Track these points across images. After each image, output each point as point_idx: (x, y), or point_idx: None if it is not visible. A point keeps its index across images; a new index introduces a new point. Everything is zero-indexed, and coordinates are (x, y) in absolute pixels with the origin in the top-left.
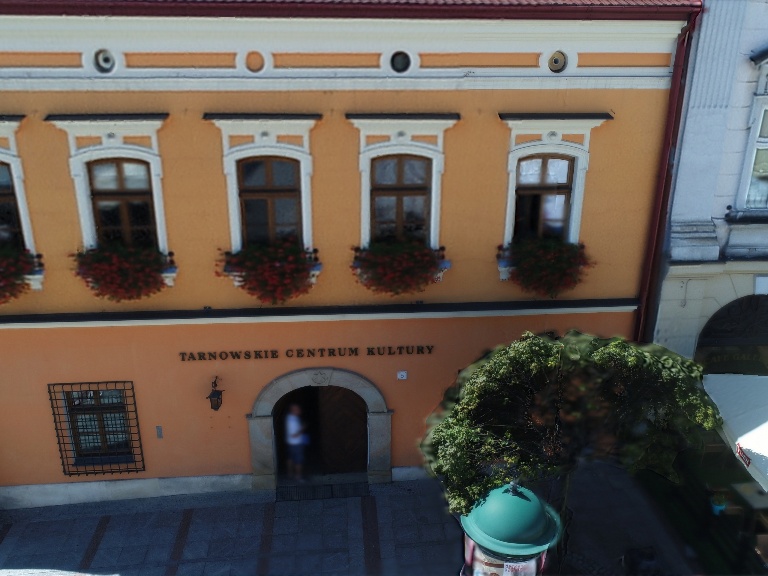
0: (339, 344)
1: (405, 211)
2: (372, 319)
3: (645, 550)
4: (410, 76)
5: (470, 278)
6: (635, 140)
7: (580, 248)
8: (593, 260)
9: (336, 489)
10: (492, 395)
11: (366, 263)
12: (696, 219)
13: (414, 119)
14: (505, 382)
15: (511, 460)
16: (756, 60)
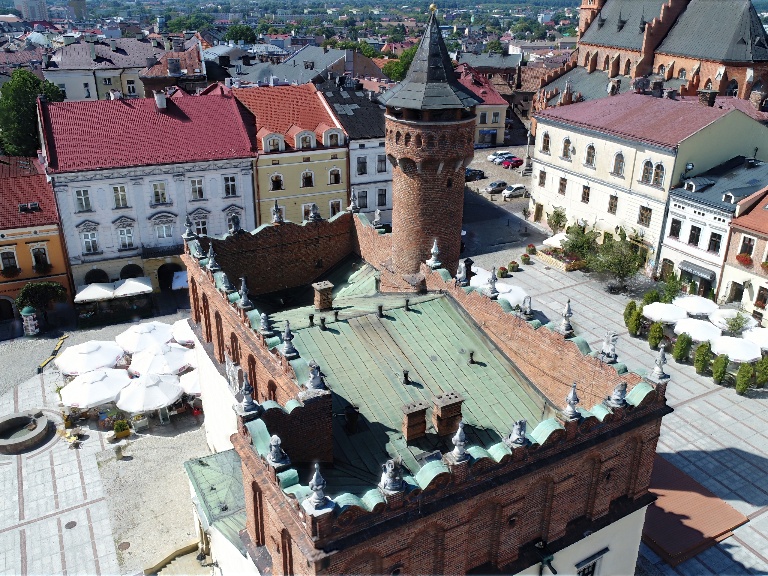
0: (1, 290)
1: (11, 262)
2: (8, 284)
3: (63, 317)
4: (5, 238)
5: (28, 273)
6: (56, 244)
7: (51, 265)
8: (54, 267)
9: (7, 322)
10: (25, 293)
11: (3, 273)
12: (75, 256)
13: (8, 246)
14: (26, 291)
15: (30, 303)
16: (77, 227)
